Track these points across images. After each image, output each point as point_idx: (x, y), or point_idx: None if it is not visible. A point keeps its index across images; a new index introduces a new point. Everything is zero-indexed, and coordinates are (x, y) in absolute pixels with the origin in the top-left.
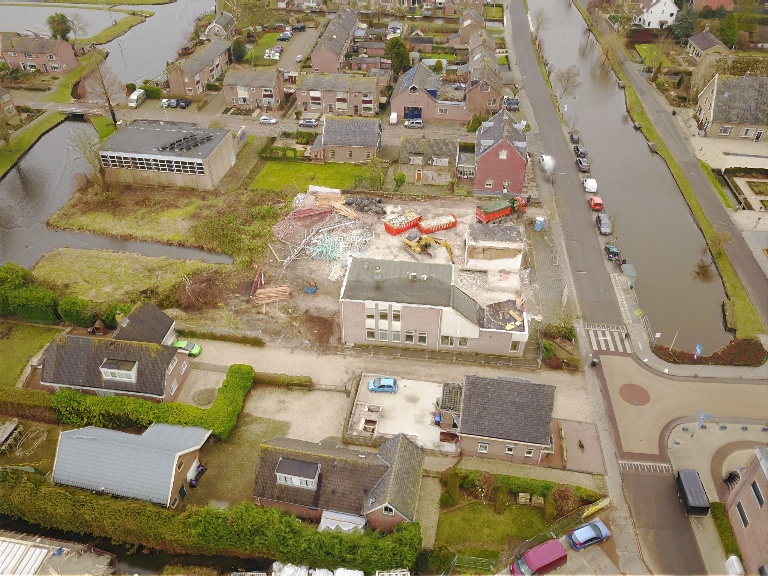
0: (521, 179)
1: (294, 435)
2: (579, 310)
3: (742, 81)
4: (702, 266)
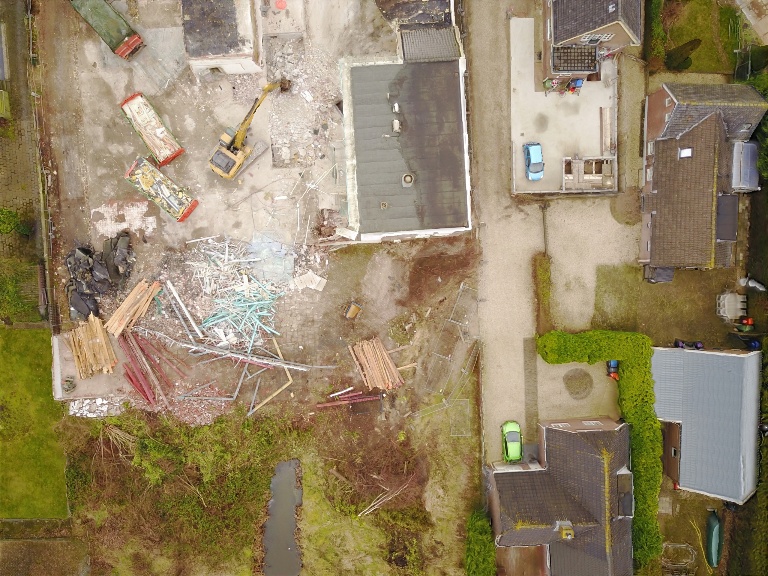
0: None
1: (615, 256)
2: None
3: None
4: None
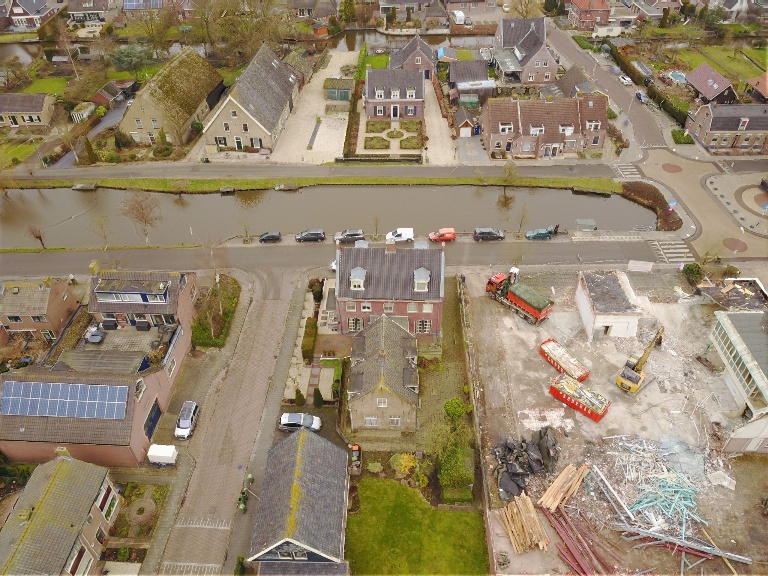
0: None
1: None
2: None
3: (243, 89)
4: (504, 199)
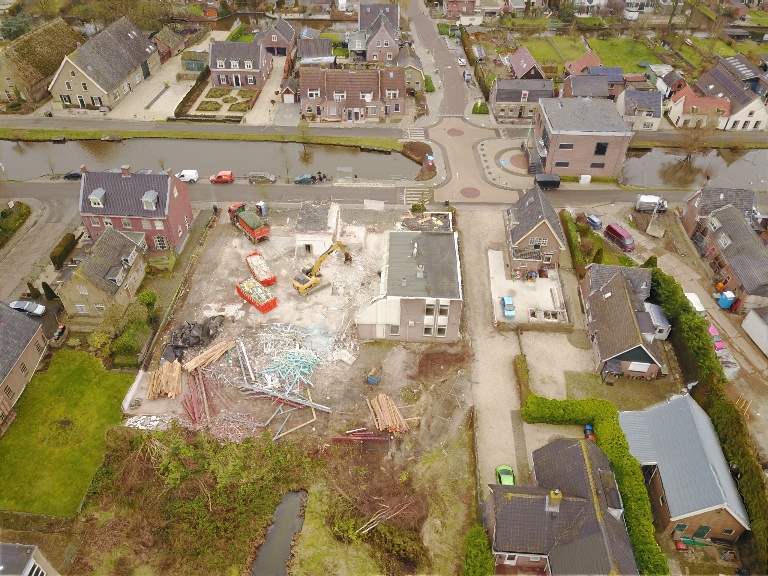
0: (189, 204)
1: (577, 366)
2: (384, 205)
3: (84, 52)
4: (304, 155)
